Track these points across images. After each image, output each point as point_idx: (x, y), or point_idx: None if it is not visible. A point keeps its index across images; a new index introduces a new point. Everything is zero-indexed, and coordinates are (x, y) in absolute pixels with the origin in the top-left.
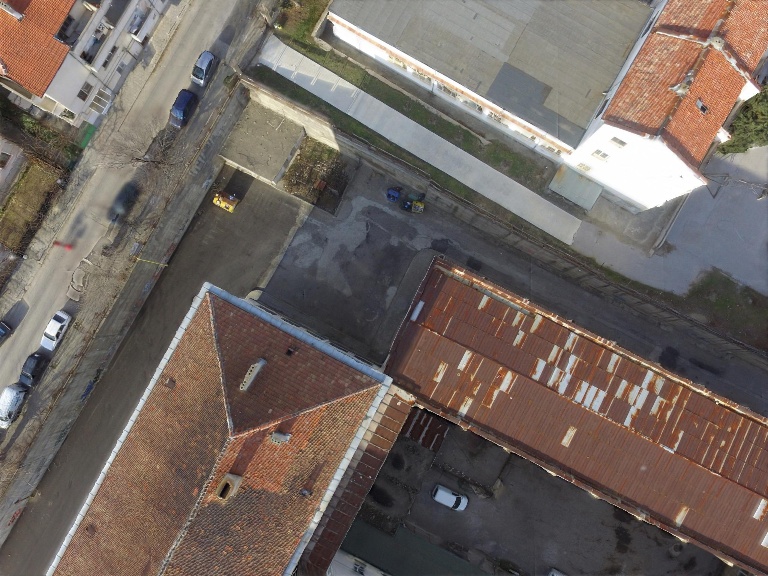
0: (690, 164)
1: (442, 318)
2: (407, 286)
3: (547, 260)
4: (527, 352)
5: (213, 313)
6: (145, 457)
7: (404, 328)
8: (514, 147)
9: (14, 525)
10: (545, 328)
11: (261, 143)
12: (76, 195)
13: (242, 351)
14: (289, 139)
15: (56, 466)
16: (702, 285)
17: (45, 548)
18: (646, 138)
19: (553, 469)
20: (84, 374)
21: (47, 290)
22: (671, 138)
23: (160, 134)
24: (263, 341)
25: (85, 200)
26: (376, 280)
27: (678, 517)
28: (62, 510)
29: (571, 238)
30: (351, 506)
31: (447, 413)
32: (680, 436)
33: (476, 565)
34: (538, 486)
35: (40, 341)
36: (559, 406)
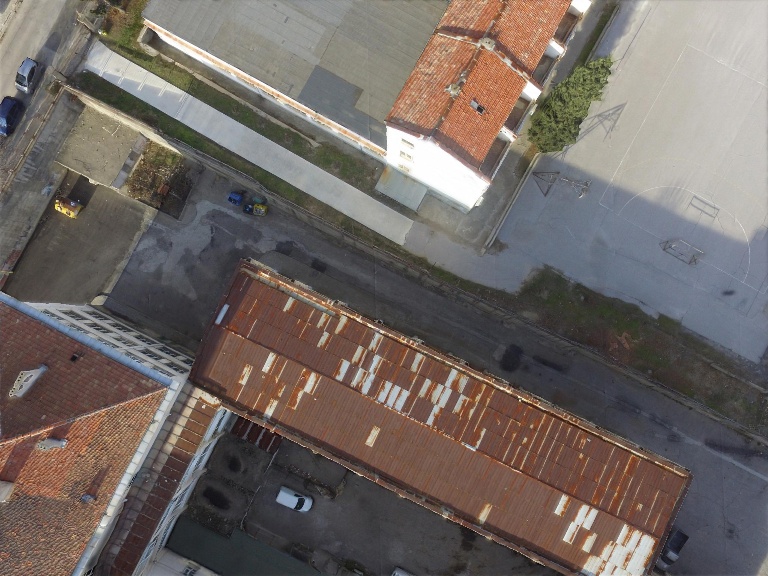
0: (469, 164)
1: (247, 321)
2: None
3: (387, 261)
4: (331, 353)
5: None
6: None
7: (209, 331)
8: (344, 149)
9: None
10: (350, 329)
11: (97, 149)
12: None
13: (23, 358)
14: (125, 144)
15: None
16: (534, 283)
17: None
18: (420, 139)
19: (357, 469)
20: None
21: None
22: (446, 139)
23: None
24: (47, 347)
25: None
26: (221, 283)
27: (481, 514)
28: None
29: (403, 238)
30: (156, 510)
31: (253, 415)
32: (482, 434)
33: (321, 565)
34: None
35: None
36: (363, 406)
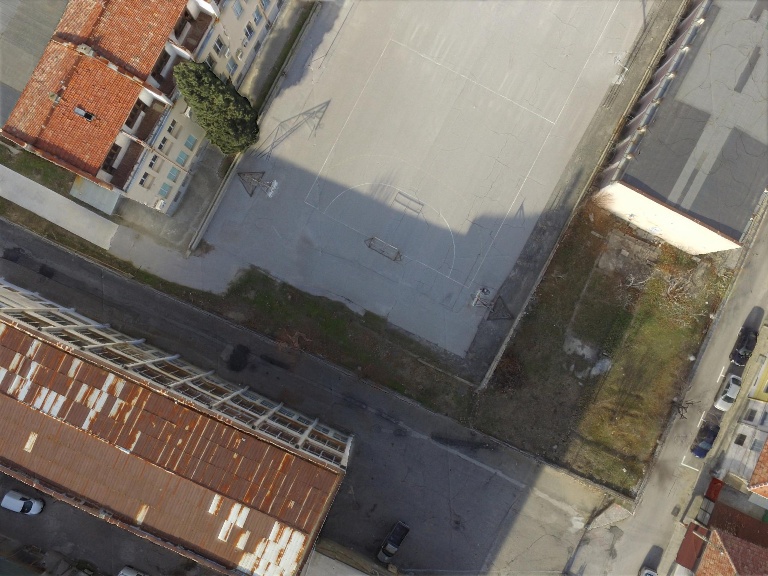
0: (80, 171)
1: None
2: None
3: None
4: None
5: None
6: None
7: None
8: None
9: None
10: (8, 336)
11: None
12: None
13: None
14: None
15: None
16: (240, 283)
17: None
18: (24, 147)
19: (15, 474)
20: None
21: None
22: (50, 146)
23: None
24: None
25: None
26: None
27: (139, 515)
28: None
29: (108, 243)
30: None
31: None
32: (137, 436)
33: (52, 566)
34: None
35: None
36: (19, 412)
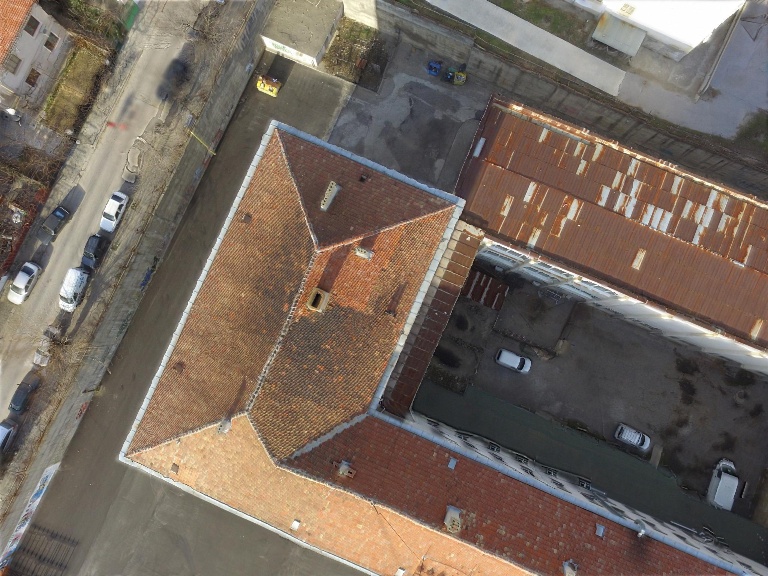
0: None
1: (504, 153)
2: (454, 157)
3: (592, 119)
4: (591, 180)
5: (284, 147)
6: (228, 289)
7: (467, 165)
8: (554, 3)
9: (81, 421)
10: (606, 156)
11: (302, 21)
12: (124, 78)
13: (317, 178)
14: (329, 15)
15: (118, 359)
16: (749, 127)
17: (113, 441)
18: None
19: (626, 292)
20: (144, 257)
21: (102, 174)
22: None
23: (204, 10)
24: (336, 170)
25: (134, 82)
26: (423, 154)
27: (753, 330)
28: (128, 402)
29: (617, 89)
30: (429, 342)
31: (516, 245)
32: (748, 250)
33: None
34: (599, 344)
35: (99, 224)
36: (627, 230)
